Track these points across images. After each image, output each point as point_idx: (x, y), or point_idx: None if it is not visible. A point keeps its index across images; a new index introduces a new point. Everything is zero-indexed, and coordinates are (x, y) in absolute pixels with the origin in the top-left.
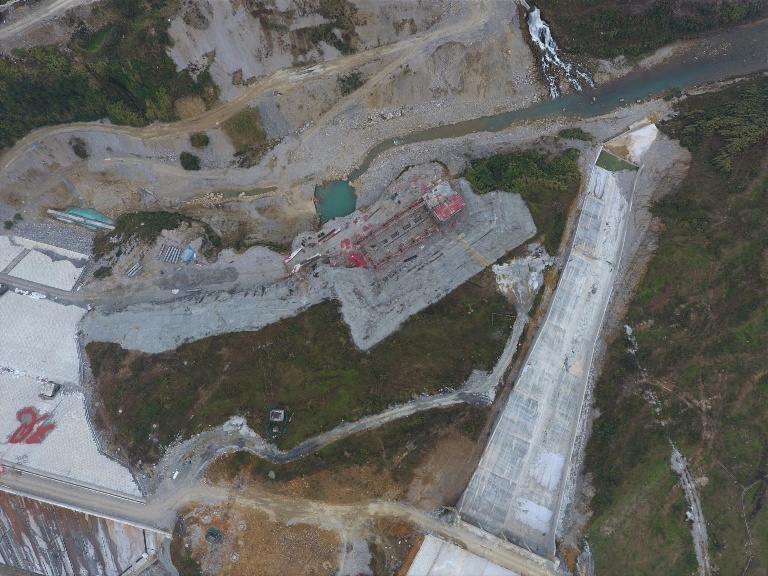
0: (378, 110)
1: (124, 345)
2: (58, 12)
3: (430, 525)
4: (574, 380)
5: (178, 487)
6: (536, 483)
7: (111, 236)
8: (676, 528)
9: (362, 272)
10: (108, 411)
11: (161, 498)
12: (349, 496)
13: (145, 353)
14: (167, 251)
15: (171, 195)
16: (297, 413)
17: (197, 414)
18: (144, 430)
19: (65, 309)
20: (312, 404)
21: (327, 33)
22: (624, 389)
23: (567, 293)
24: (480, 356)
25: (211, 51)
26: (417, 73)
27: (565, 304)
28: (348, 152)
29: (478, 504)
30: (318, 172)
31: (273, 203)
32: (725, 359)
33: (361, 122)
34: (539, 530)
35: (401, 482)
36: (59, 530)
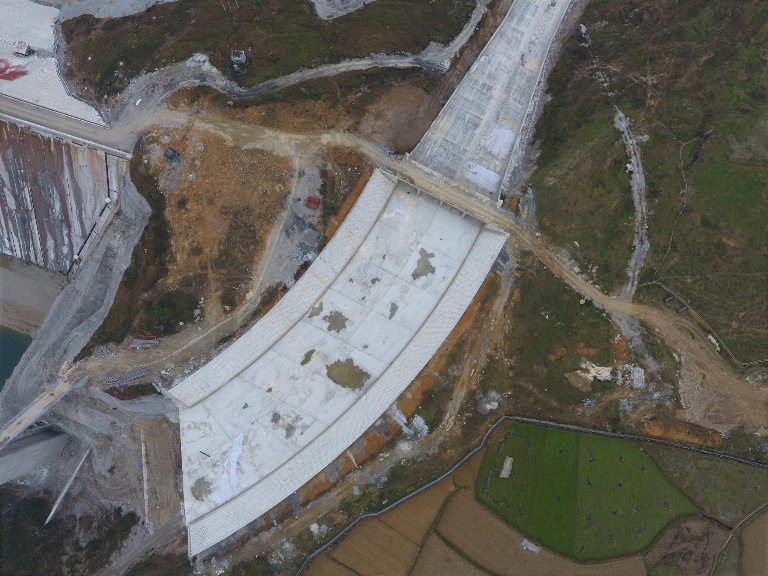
0: None
1: (97, 15)
2: None
3: (380, 159)
4: (529, 73)
5: (140, 112)
6: (486, 151)
7: None
8: (616, 179)
9: None
10: (78, 58)
11: (124, 122)
12: (303, 126)
13: (117, 17)
14: None
15: None
16: (258, 60)
17: (162, 54)
18: (111, 65)
19: (44, 8)
20: (273, 53)
21: None
22: (575, 74)
23: (527, 3)
24: (438, 34)
25: None
26: None
27: (525, 11)
28: None
29: (429, 162)
30: None
31: None
32: (673, 45)
33: None
34: (486, 189)
35: (353, 114)
36: (26, 174)
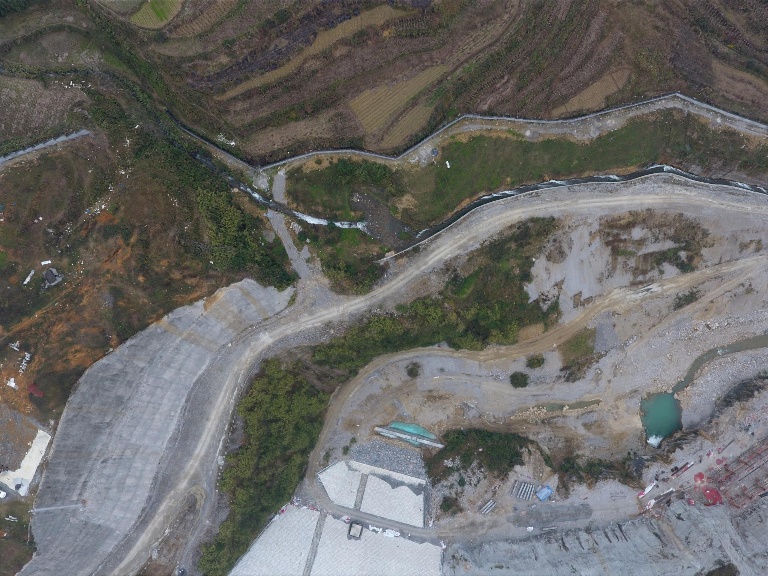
0: (705, 321)
1: None
2: (437, 263)
3: None
4: None
5: None
6: None
7: (445, 459)
8: None
9: (723, 512)
10: None
11: None
12: None
13: None
14: (521, 488)
15: (495, 410)
16: None
17: None
18: None
19: (422, 548)
20: None
21: (673, 255)
22: None
23: None
24: None
25: (561, 280)
26: (759, 291)
27: None
28: (674, 364)
29: None
30: (644, 385)
31: (599, 418)
32: None
33: (687, 333)
34: None
35: None
36: None
